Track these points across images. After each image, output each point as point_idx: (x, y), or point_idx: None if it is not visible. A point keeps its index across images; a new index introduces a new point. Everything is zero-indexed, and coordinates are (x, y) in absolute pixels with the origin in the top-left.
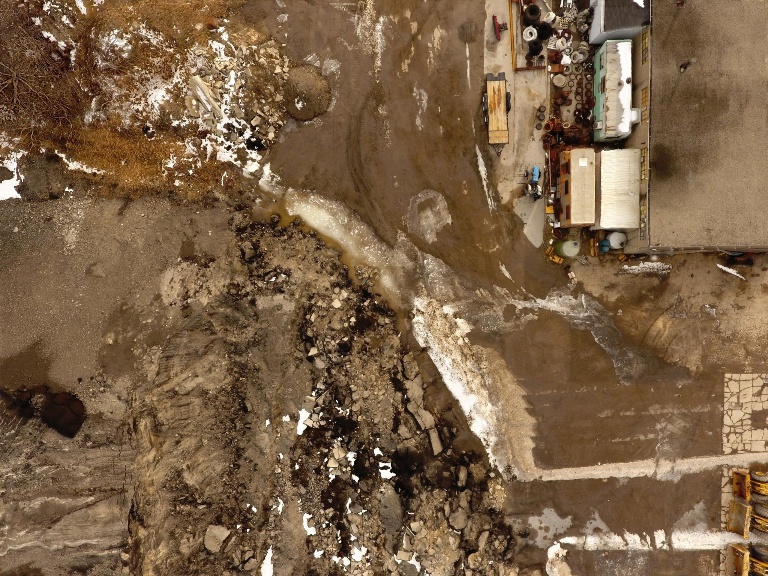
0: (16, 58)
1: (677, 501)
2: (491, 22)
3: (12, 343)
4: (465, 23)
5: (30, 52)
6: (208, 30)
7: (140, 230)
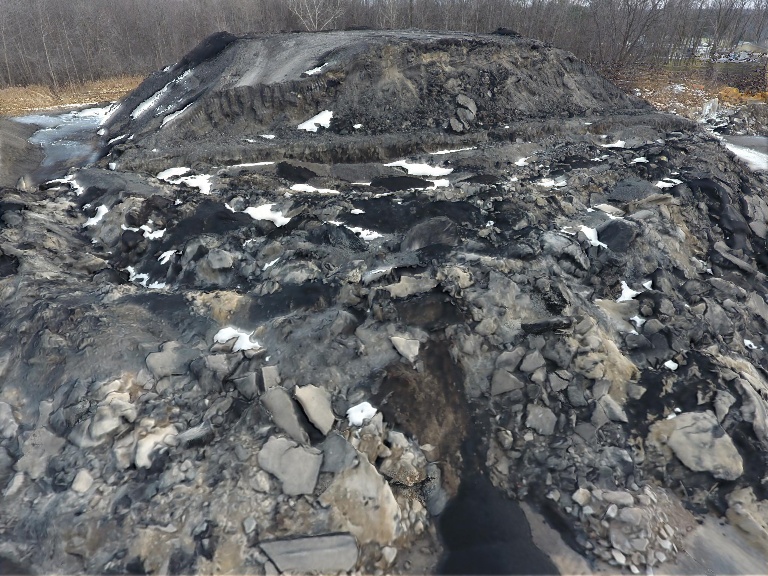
0: None
1: None
2: None
3: None
4: None
5: None
6: None
7: None
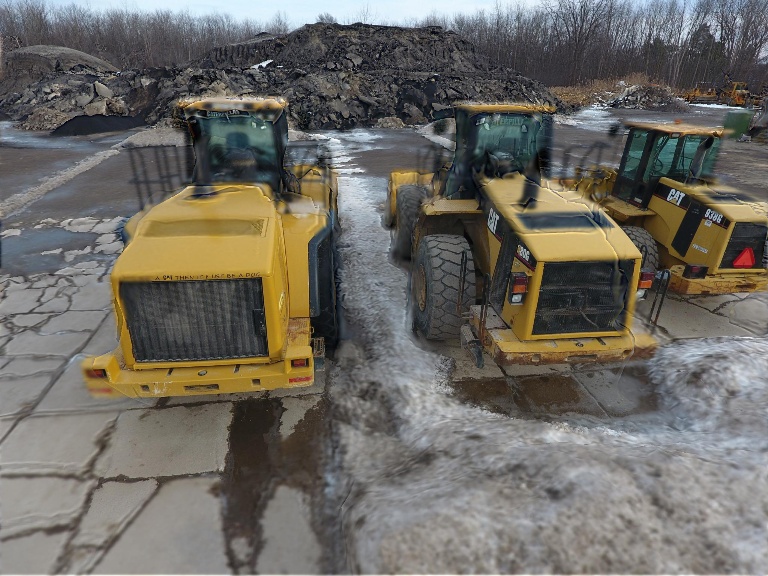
0: None
1: None
2: None
3: None
4: None
5: None
6: None
7: None
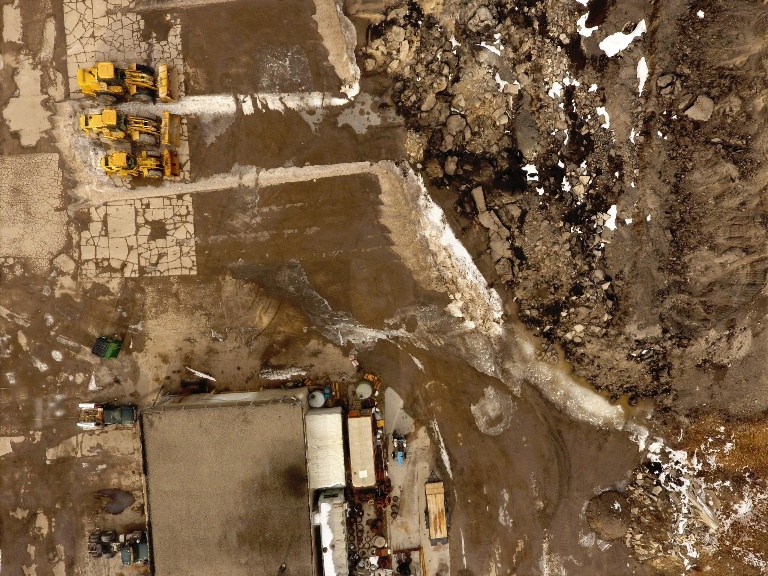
0: None
1: (233, 145)
2: None
3: None
4: None
5: None
6: (698, 566)
7: (762, 389)
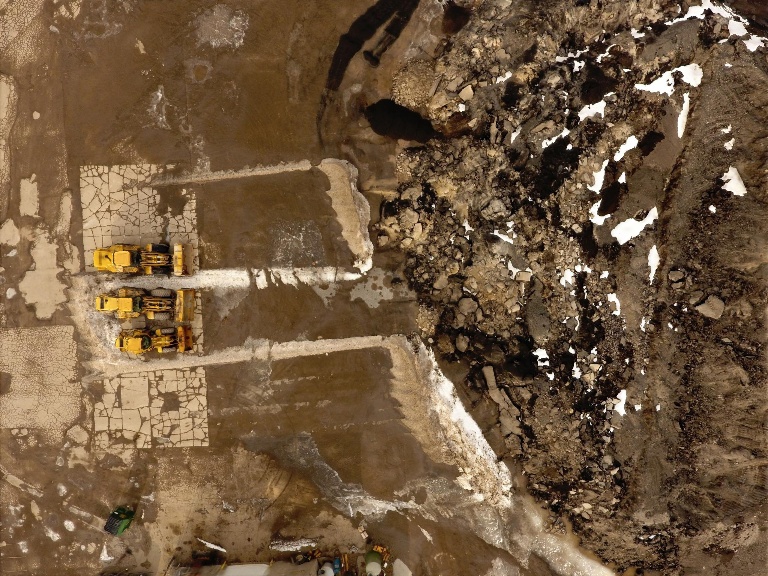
0: None
1: (247, 318)
2: None
3: None
4: None
5: None
6: None
7: (767, 571)
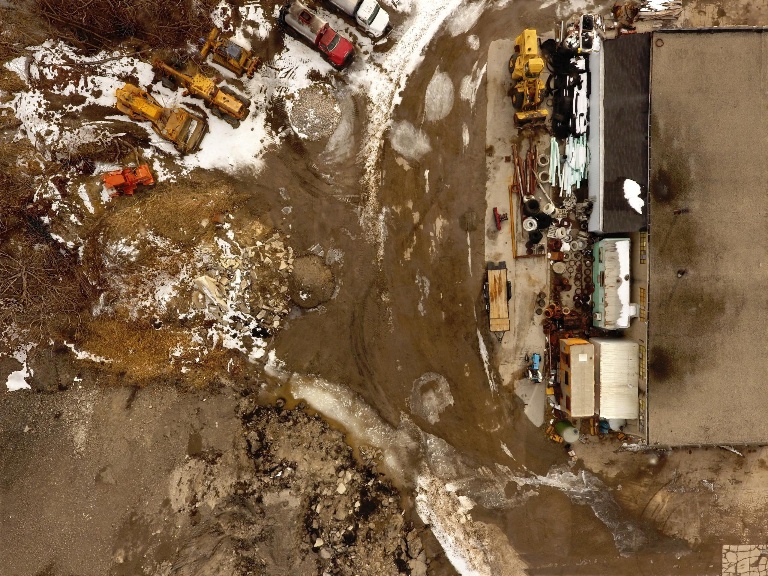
0: (25, 252)
1: None
2: (492, 212)
3: (25, 570)
4: (466, 213)
5: (39, 246)
6: (214, 225)
7: (148, 426)
